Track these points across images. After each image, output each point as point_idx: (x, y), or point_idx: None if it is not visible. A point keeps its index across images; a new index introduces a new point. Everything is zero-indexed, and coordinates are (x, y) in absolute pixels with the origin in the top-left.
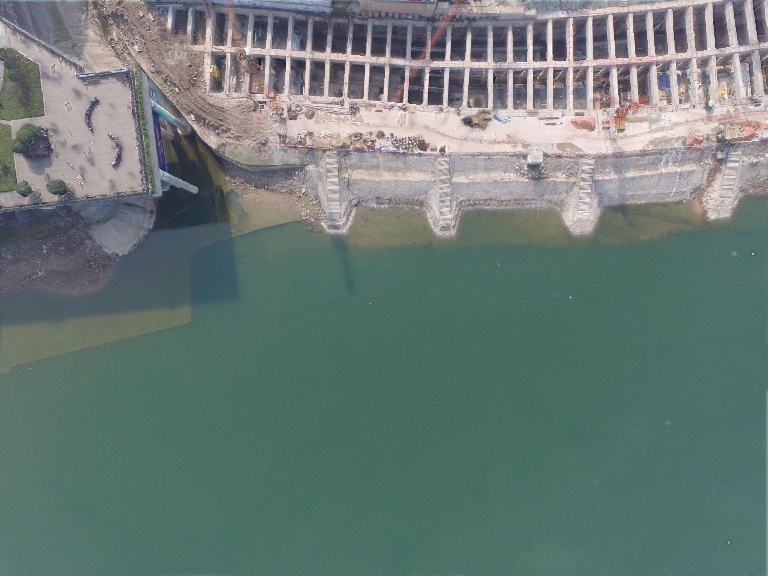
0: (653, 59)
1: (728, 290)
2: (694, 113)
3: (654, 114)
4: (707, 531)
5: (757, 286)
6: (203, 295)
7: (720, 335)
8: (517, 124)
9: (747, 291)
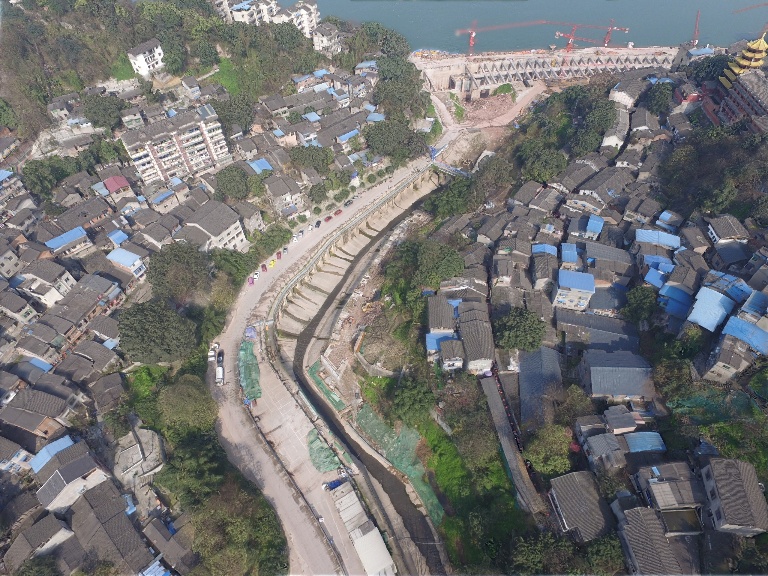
0: (589, 65)
1: (528, 38)
2: (566, 55)
3: (583, 55)
4: (523, 4)
5: (517, 39)
6: (748, 37)
7: (529, 31)
8: (642, 53)
9: (520, 38)
